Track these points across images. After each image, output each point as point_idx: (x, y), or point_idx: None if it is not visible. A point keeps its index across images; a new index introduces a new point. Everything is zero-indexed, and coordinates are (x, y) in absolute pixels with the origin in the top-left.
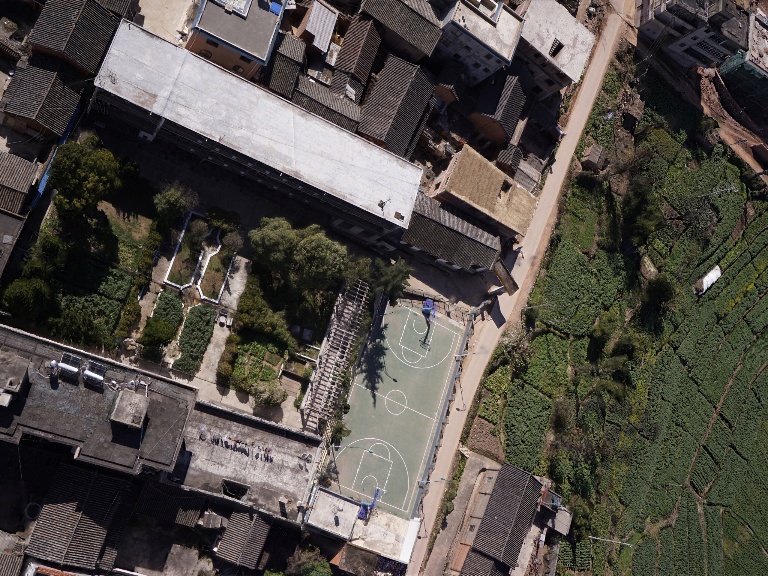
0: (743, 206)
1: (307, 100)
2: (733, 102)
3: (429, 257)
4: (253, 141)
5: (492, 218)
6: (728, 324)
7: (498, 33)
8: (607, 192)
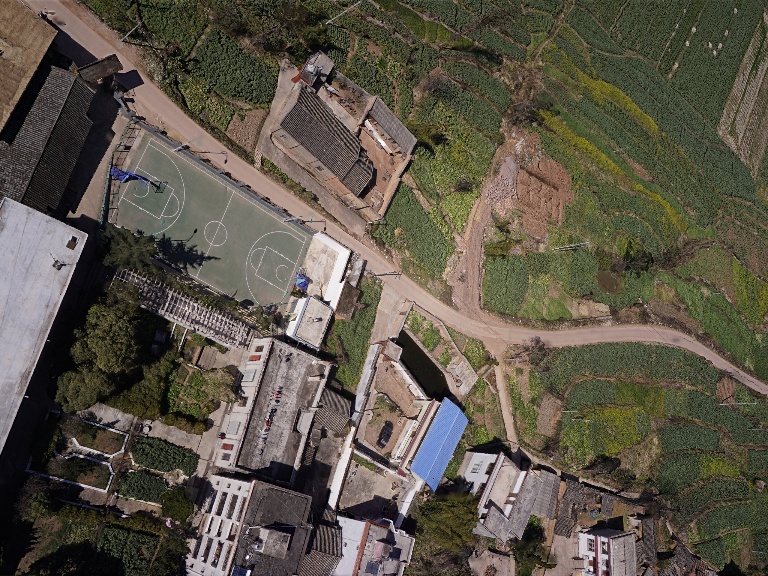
0: None
1: None
2: None
3: None
4: None
5: None
6: None
7: None
8: None
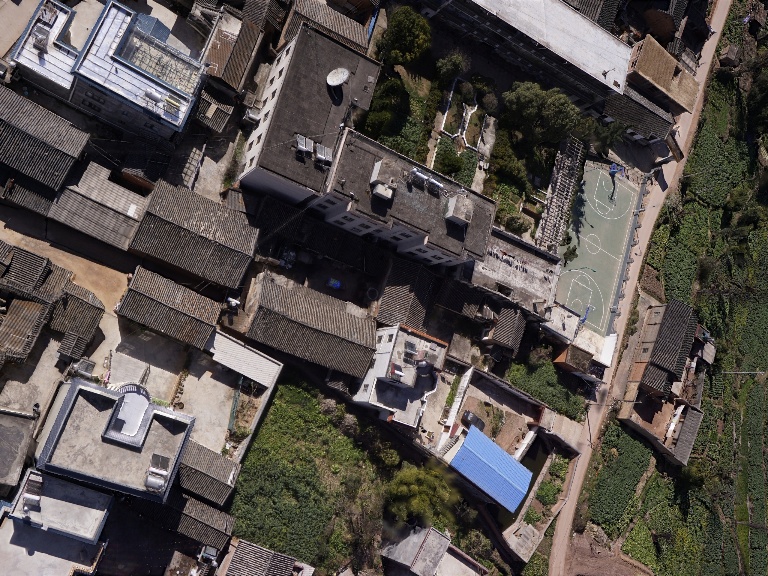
0: None
1: None
2: None
3: None
4: (518, 16)
5: (668, 96)
6: None
7: None
8: (736, 88)
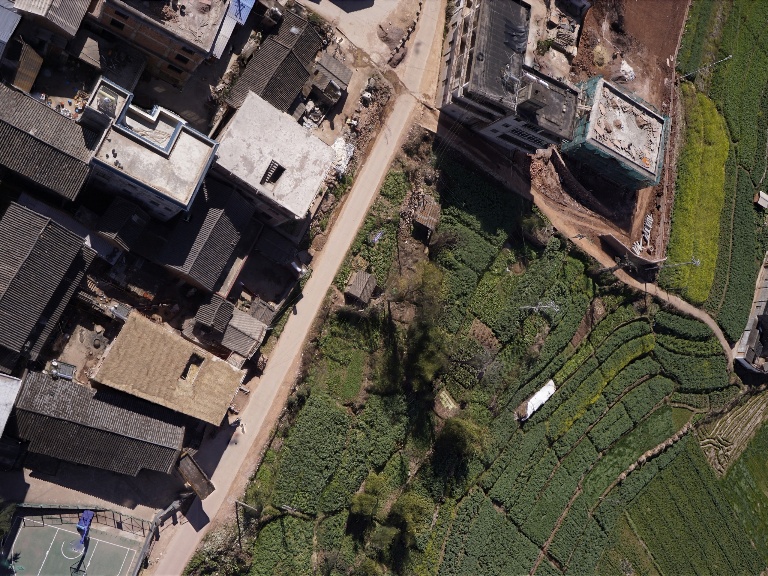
0: (588, 306)
1: None
2: (577, 184)
3: None
4: None
5: (169, 408)
6: (564, 446)
7: (172, 167)
8: (385, 322)
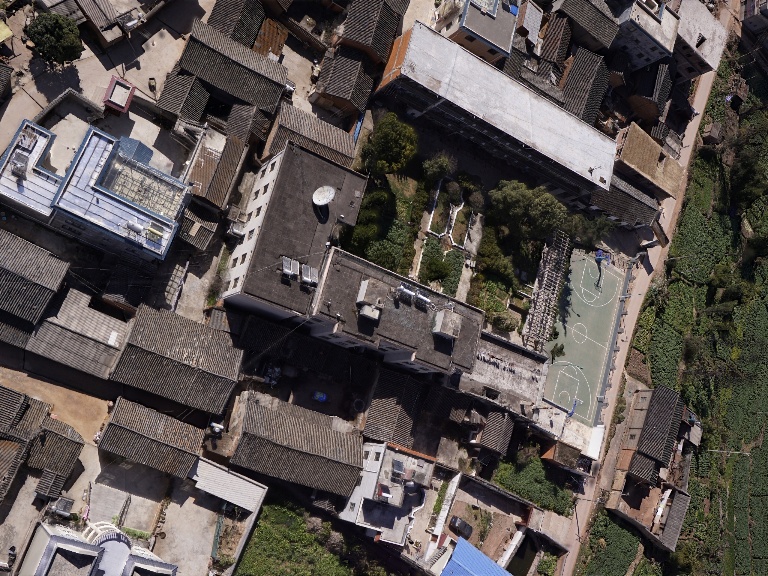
0: None
1: (527, 85)
2: None
3: (600, 215)
4: (504, 118)
5: (653, 183)
6: None
7: (662, 29)
8: (719, 163)
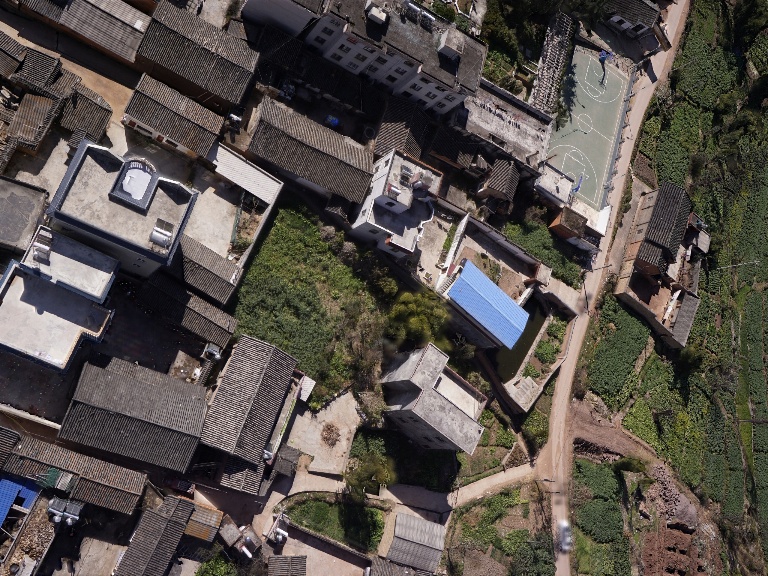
0: None
1: None
2: None
3: (603, 18)
4: None
5: None
6: None
7: None
8: (722, 0)
